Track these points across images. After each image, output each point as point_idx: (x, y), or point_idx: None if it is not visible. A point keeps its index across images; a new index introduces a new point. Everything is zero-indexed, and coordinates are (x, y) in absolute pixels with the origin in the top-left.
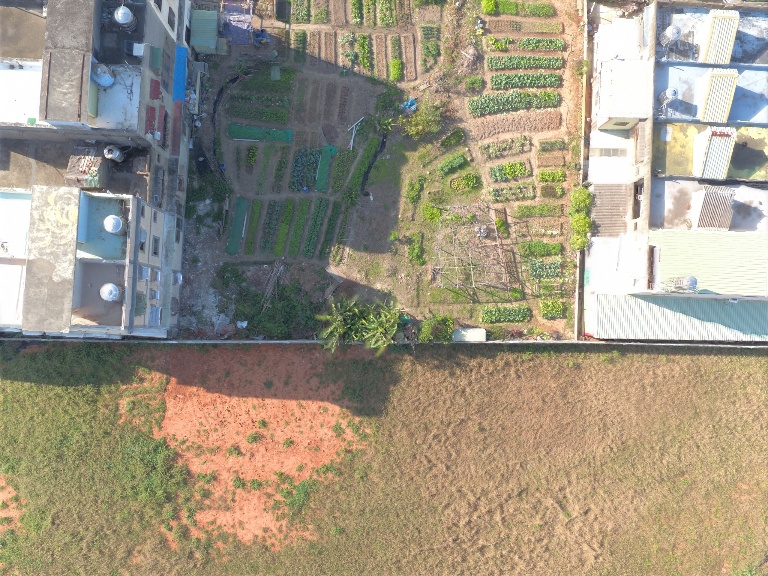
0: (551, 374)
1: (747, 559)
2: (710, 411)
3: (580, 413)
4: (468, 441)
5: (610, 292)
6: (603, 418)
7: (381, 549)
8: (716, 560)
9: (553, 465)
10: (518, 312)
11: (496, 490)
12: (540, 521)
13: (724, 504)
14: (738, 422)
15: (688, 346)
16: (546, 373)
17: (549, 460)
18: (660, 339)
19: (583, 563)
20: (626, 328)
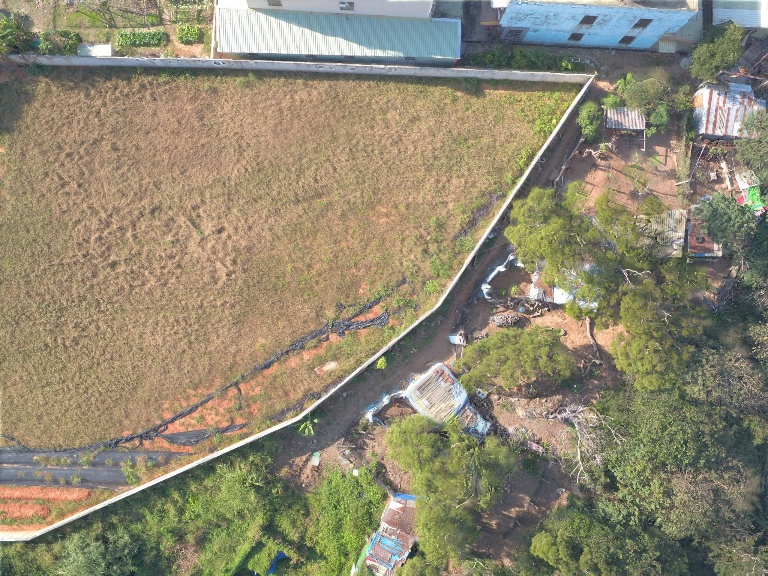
0: (187, 97)
1: (383, 279)
2: (348, 135)
3: (216, 135)
4: (101, 160)
5: (233, 7)
6: (238, 140)
7: (10, 263)
8: (352, 280)
9: (186, 184)
10: (153, 35)
11: (127, 207)
12: (171, 238)
13: (361, 225)
14: (375, 146)
15: (327, 73)
16: (182, 96)
17: (183, 179)
18: (283, 53)
19: (216, 281)
20: (249, 42)
